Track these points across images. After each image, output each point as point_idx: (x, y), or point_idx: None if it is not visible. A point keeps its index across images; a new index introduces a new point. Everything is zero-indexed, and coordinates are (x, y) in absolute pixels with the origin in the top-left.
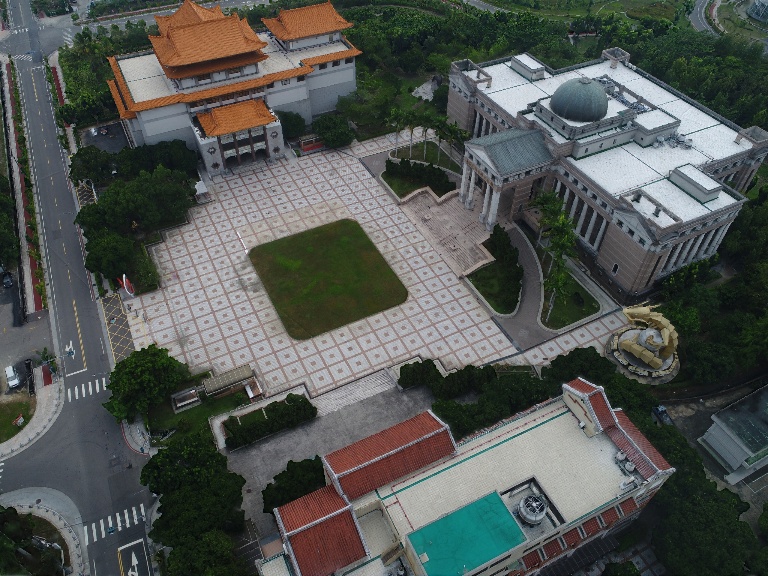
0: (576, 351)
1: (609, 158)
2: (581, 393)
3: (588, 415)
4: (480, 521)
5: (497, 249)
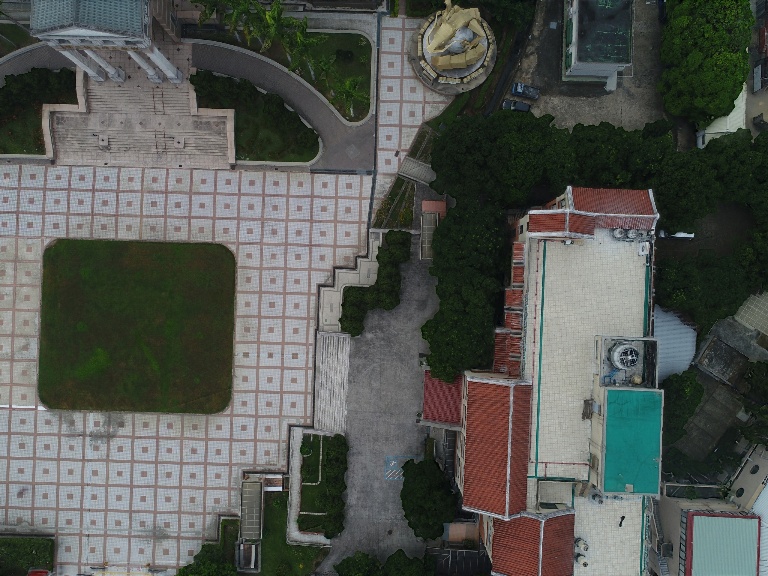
0: (452, 151)
1: None
2: (560, 235)
3: None
4: (625, 421)
5: (222, 99)
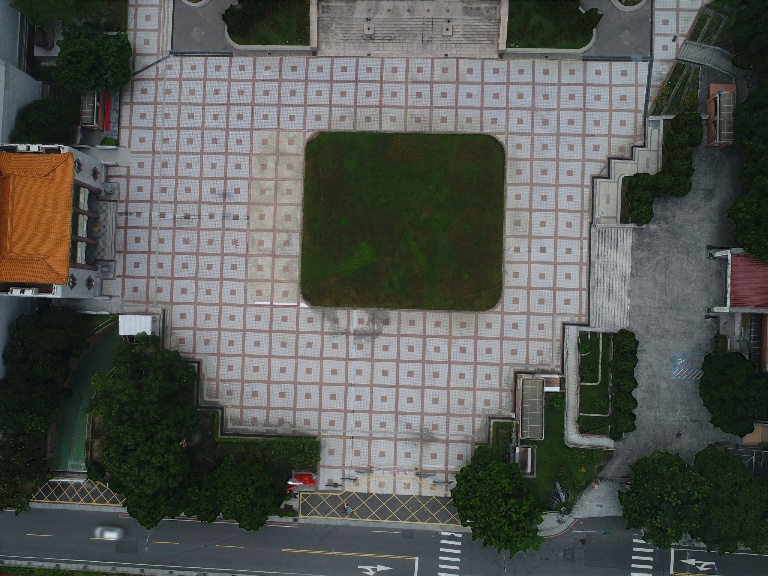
0: None
1: None
2: None
3: None
4: None
5: None
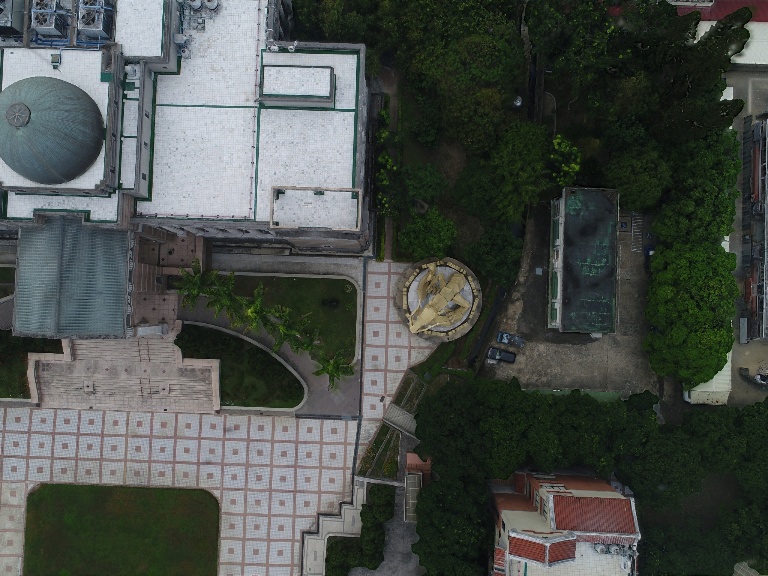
0: (435, 434)
1: (173, 148)
2: None
3: None
4: None
5: None
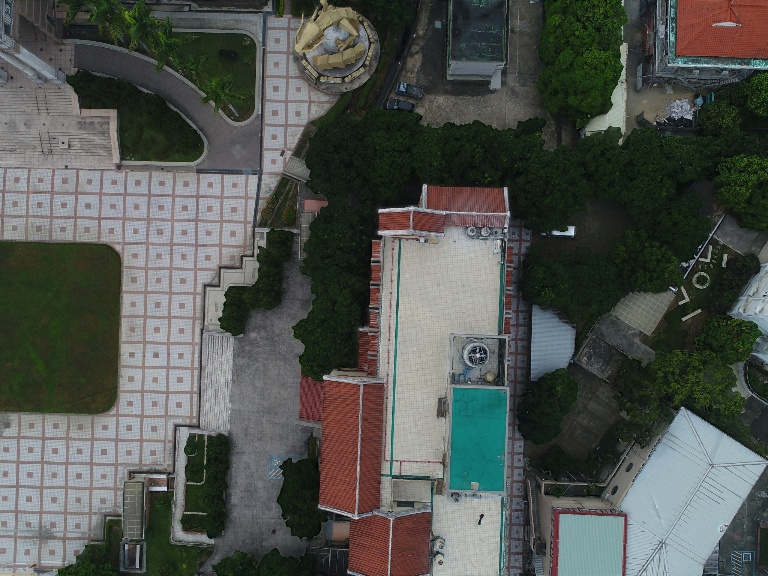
0: (319, 150)
1: None
2: (405, 233)
3: (424, 236)
4: (471, 419)
5: None
